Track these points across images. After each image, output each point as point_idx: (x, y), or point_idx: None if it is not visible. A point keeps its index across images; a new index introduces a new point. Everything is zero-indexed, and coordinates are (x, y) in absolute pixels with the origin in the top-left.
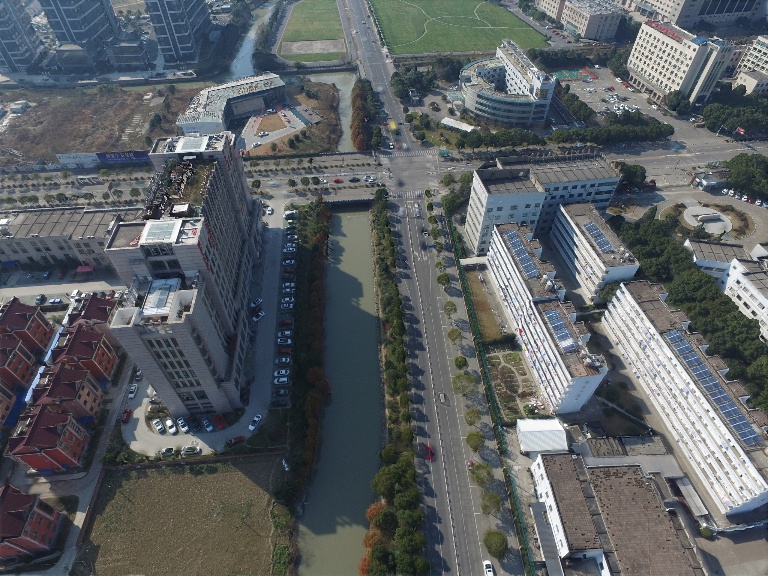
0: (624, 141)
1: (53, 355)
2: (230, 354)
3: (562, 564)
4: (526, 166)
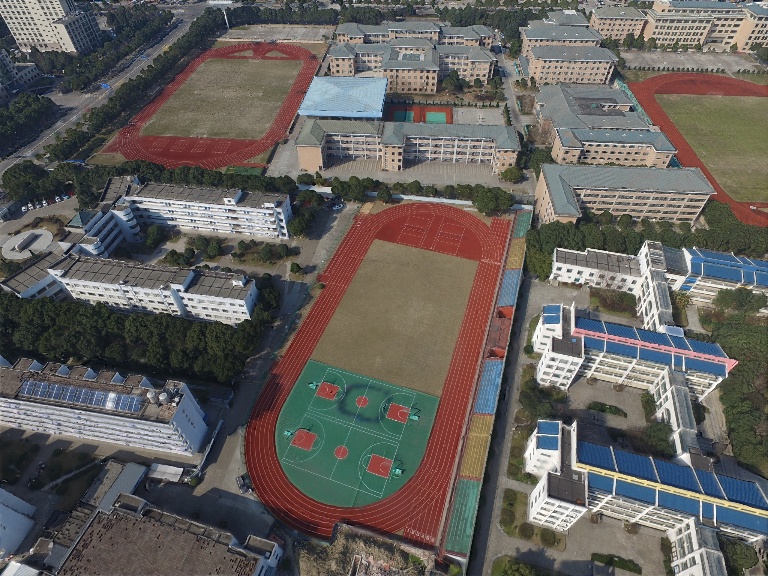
0: None
1: None
2: None
3: None
4: None
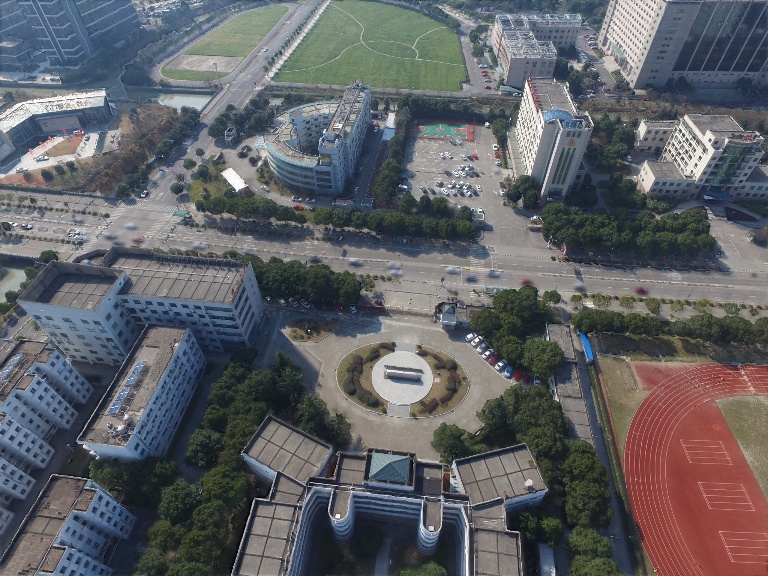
0: (404, 235)
1: None
2: None
3: None
4: (144, 263)
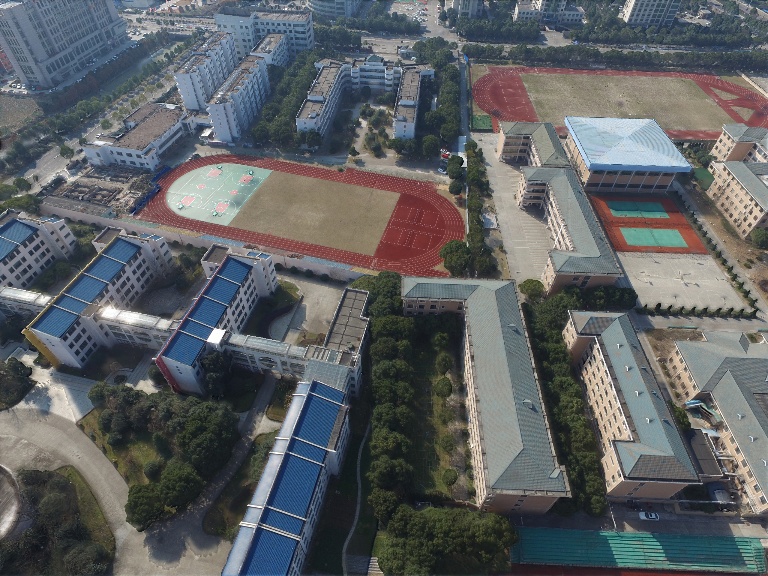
0: (384, 30)
1: None
2: (50, 57)
3: None
4: None
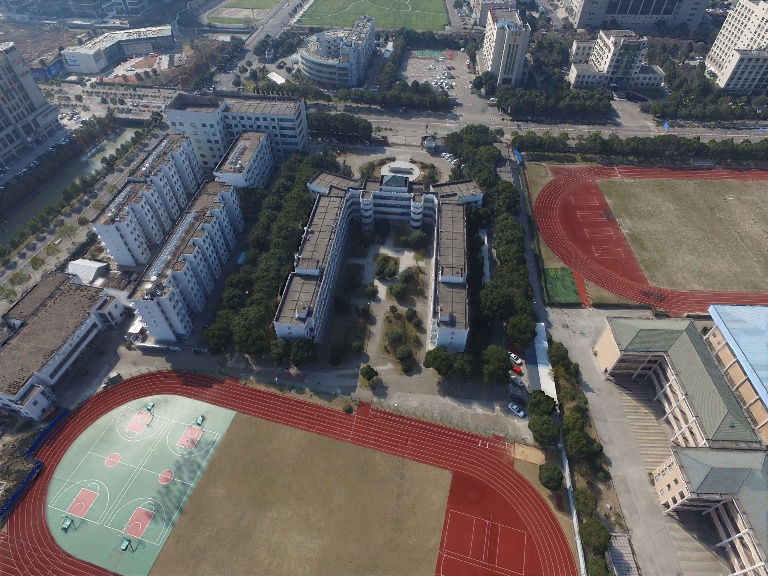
0: (401, 106)
1: None
2: None
3: None
4: (235, 99)
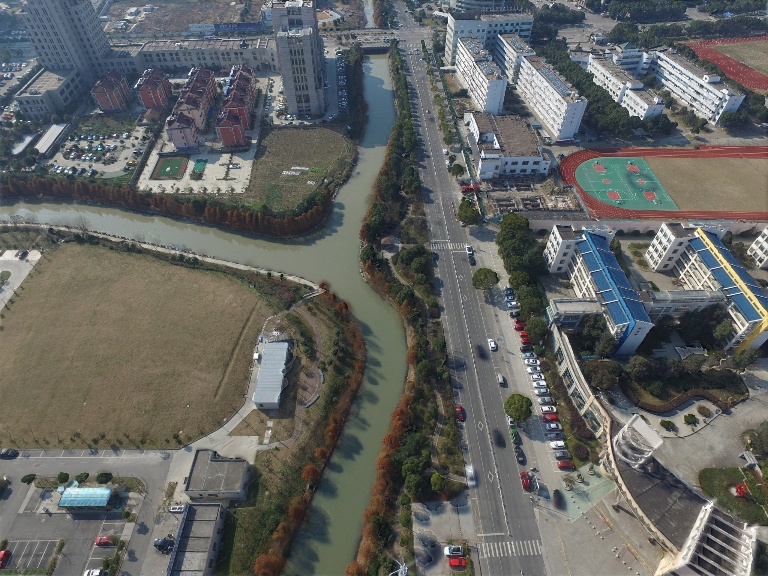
0: (552, 22)
1: (231, 82)
2: (319, 83)
3: (477, 144)
4: None
